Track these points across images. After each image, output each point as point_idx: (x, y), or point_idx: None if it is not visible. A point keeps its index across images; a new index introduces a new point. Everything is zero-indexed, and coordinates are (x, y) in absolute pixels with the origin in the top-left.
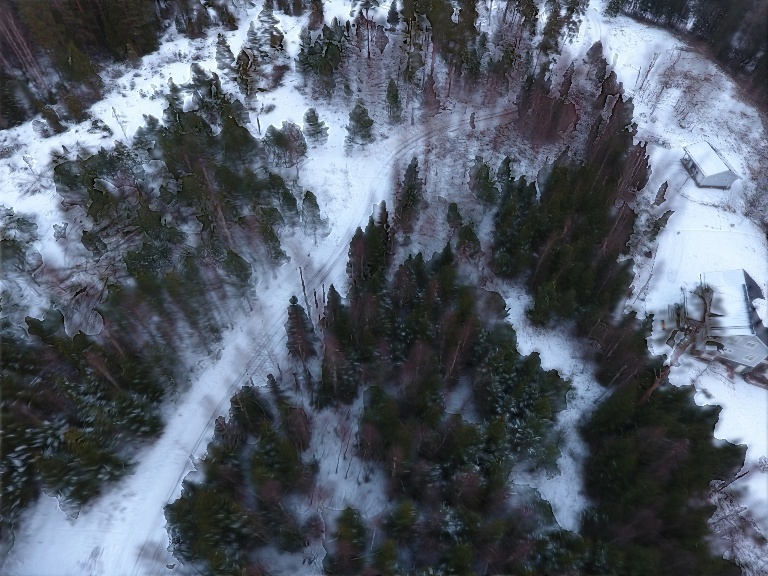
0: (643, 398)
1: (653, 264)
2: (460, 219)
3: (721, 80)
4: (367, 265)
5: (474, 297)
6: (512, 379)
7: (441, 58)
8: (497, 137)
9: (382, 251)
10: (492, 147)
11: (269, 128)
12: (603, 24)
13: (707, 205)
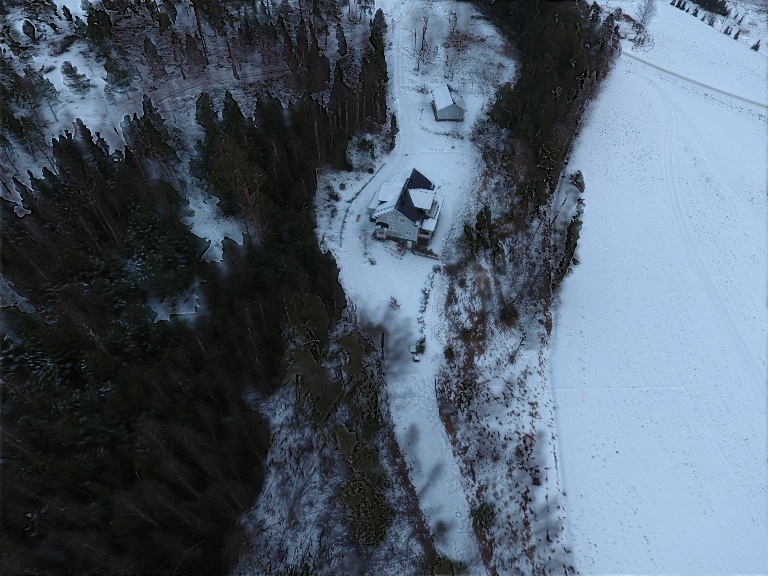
0: (253, 242)
1: (372, 178)
2: (158, 134)
3: (494, 40)
4: (66, 169)
5: (134, 181)
6: (148, 234)
7: (203, 20)
8: (263, 87)
9: (77, 157)
10: (254, 95)
11: (11, 74)
12: (418, 0)
13: (440, 134)
